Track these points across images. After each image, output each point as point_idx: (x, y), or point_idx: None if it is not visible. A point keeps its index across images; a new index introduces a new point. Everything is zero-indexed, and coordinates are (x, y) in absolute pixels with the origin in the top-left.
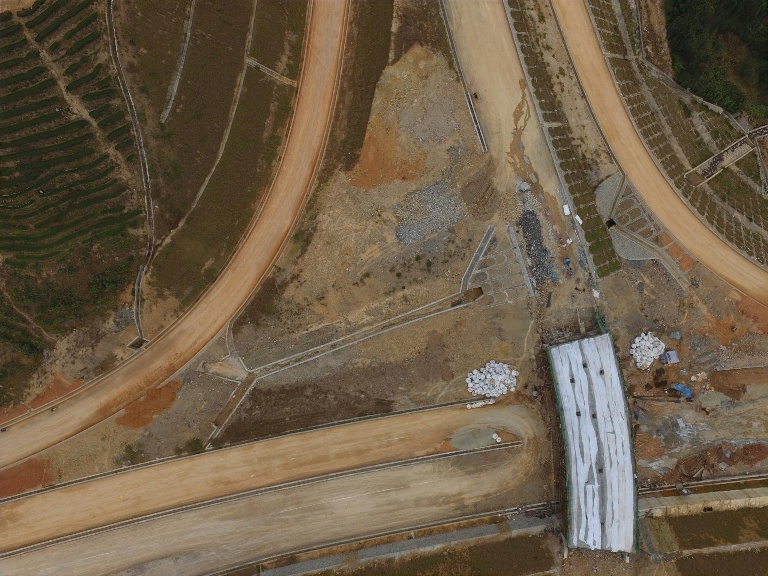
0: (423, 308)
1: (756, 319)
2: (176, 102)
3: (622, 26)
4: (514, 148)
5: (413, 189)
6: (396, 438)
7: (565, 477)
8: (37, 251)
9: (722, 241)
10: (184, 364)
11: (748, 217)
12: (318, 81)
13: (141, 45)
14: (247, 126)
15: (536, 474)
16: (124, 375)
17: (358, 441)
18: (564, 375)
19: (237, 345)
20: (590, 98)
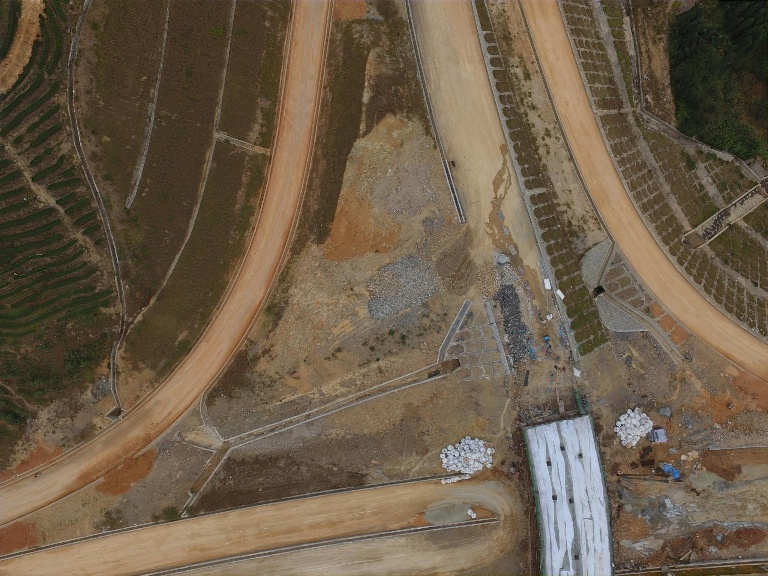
0: (399, 379)
1: (755, 396)
2: (141, 187)
3: (618, 76)
4: (493, 218)
5: (386, 262)
6: (369, 511)
7: (539, 561)
8: (15, 329)
9: (720, 312)
10: (159, 435)
11: (753, 281)
12: (292, 148)
13: (104, 133)
14: (217, 201)
15: (512, 551)
16: (103, 443)
17: (331, 513)
18: (540, 457)
19: (211, 416)
20: (578, 160)
